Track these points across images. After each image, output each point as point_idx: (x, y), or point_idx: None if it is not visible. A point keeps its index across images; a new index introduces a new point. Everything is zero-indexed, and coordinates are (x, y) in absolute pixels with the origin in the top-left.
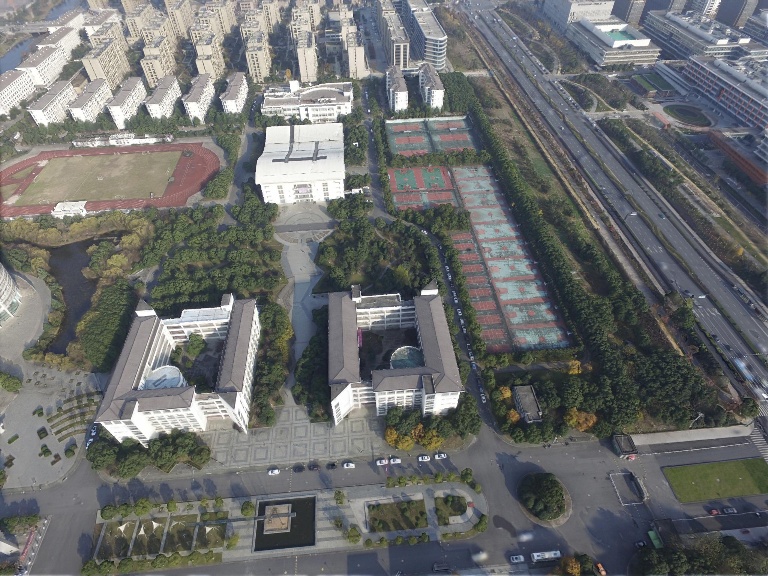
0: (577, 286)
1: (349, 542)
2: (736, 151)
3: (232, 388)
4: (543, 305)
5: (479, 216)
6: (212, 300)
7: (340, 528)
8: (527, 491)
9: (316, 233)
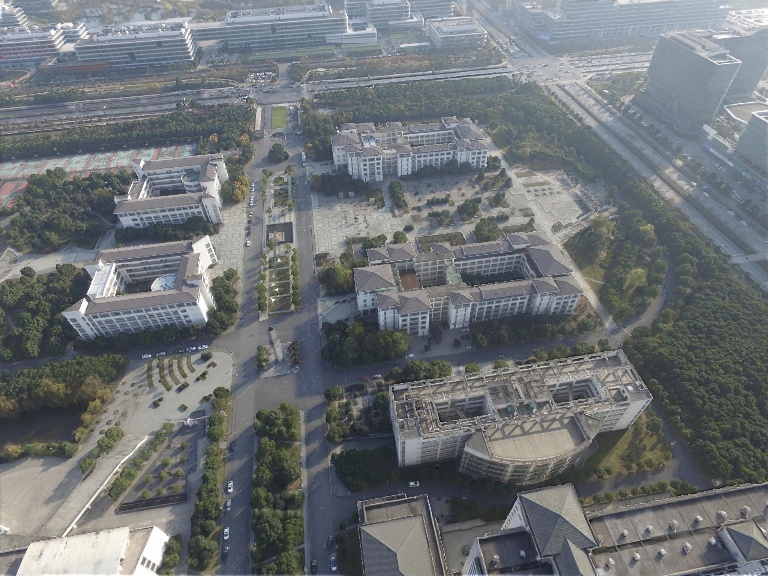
0: (157, 129)
1: (292, 211)
2: (71, 66)
3: (188, 243)
4: (162, 149)
5: (53, 169)
6: (74, 296)
7: (285, 214)
8: (276, 156)
9: (5, 259)
